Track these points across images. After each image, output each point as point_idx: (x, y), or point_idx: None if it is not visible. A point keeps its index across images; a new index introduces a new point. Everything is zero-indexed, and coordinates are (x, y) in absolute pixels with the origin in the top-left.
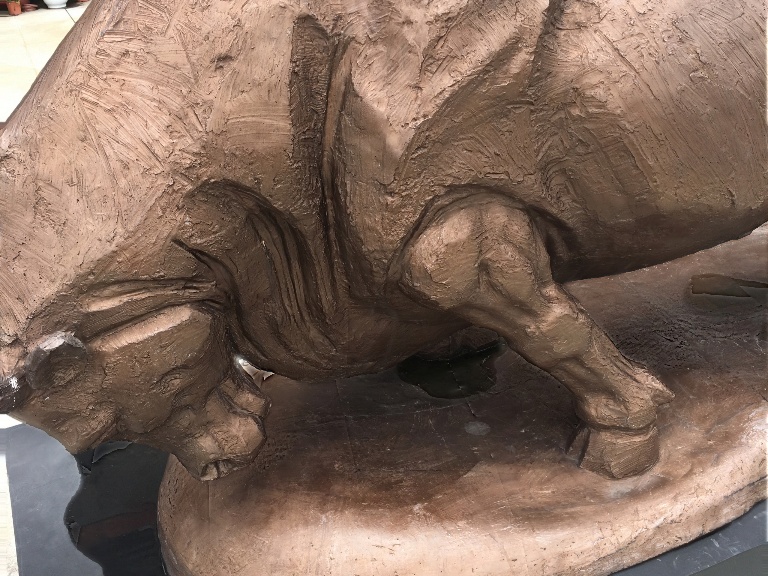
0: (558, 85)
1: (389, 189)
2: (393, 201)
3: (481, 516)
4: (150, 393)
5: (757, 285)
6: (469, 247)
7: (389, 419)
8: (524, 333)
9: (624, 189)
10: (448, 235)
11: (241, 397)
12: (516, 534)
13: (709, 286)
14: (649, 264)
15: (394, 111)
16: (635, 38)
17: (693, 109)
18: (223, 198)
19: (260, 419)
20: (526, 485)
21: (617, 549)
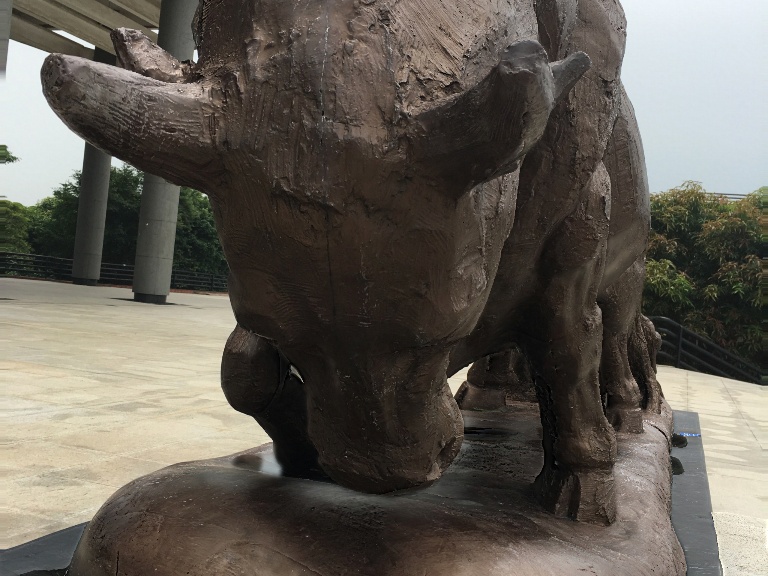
0: None
1: (609, 88)
2: (610, 102)
3: None
4: None
5: (478, 428)
6: None
7: None
8: (583, 328)
9: (619, 196)
10: None
11: None
12: (630, 558)
13: None
14: None
15: (609, 13)
16: None
17: None
18: None
19: None
20: None
21: (675, 571)
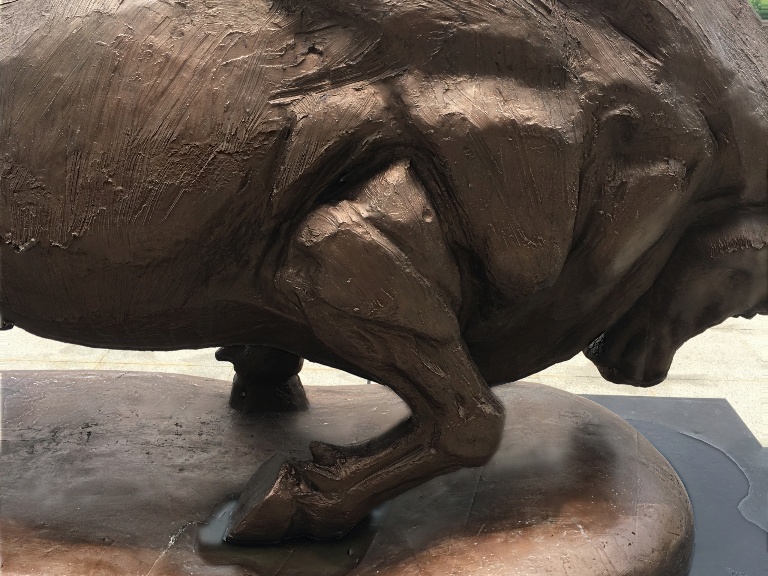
0: None
1: None
2: None
3: None
4: None
5: None
6: None
7: None
8: None
9: None
10: None
11: None
12: None
13: None
14: None
15: None
16: None
17: None
18: None
19: None
20: None
21: None
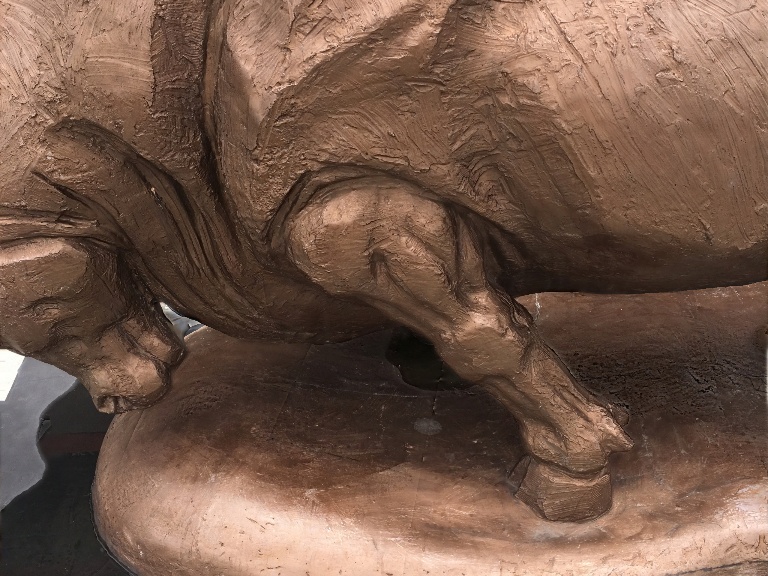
0: (483, 66)
1: (253, 155)
2: (258, 169)
3: (374, 519)
4: (21, 317)
5: None
6: (355, 233)
7: (339, 395)
8: (441, 338)
9: (564, 198)
10: (330, 215)
11: (146, 339)
12: (402, 548)
13: None
14: (647, 290)
15: (260, 71)
16: (590, 21)
17: (656, 117)
18: (93, 138)
19: (164, 365)
20: (444, 499)
21: None
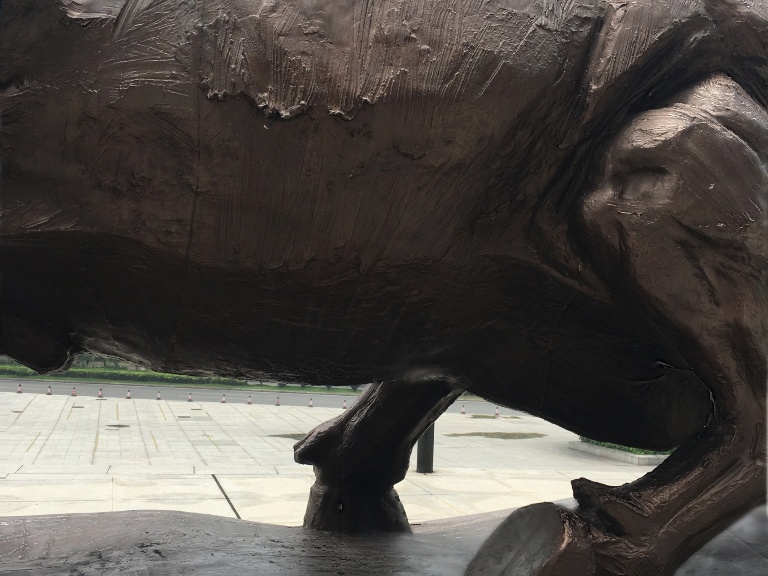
0: None
1: None
2: None
3: None
4: None
5: None
6: None
7: None
8: None
9: None
10: None
11: None
12: None
13: None
14: None
15: None
16: None
17: None
18: None
19: None
20: None
21: None
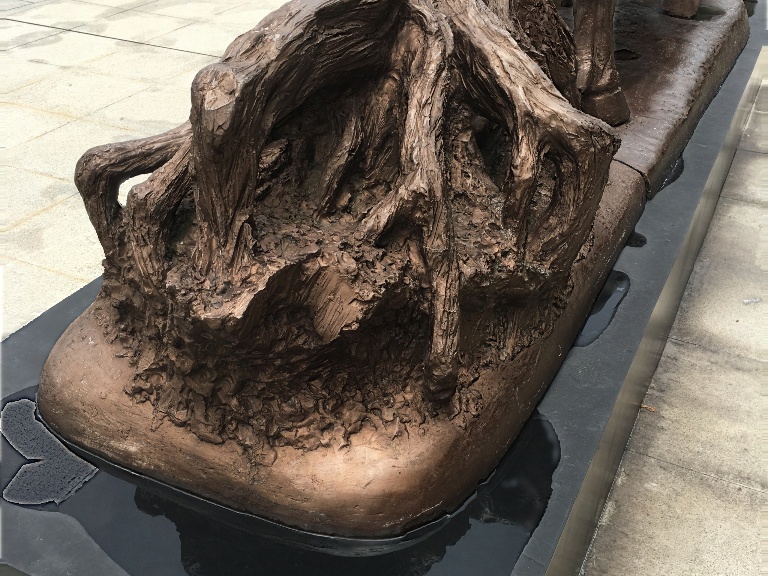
0: None
1: None
2: None
3: None
4: None
5: None
6: None
7: None
8: None
9: None
10: None
11: None
12: None
13: (624, 53)
14: None
15: None
16: None
17: None
18: None
19: None
20: None
21: None
